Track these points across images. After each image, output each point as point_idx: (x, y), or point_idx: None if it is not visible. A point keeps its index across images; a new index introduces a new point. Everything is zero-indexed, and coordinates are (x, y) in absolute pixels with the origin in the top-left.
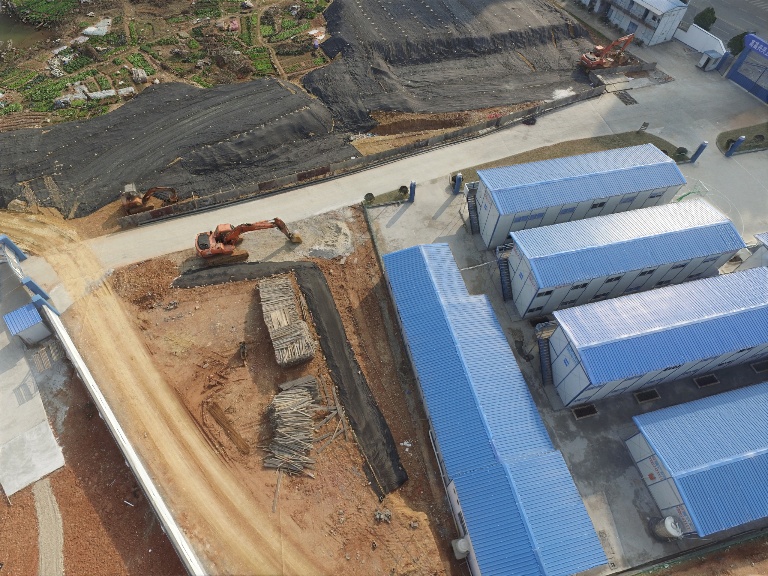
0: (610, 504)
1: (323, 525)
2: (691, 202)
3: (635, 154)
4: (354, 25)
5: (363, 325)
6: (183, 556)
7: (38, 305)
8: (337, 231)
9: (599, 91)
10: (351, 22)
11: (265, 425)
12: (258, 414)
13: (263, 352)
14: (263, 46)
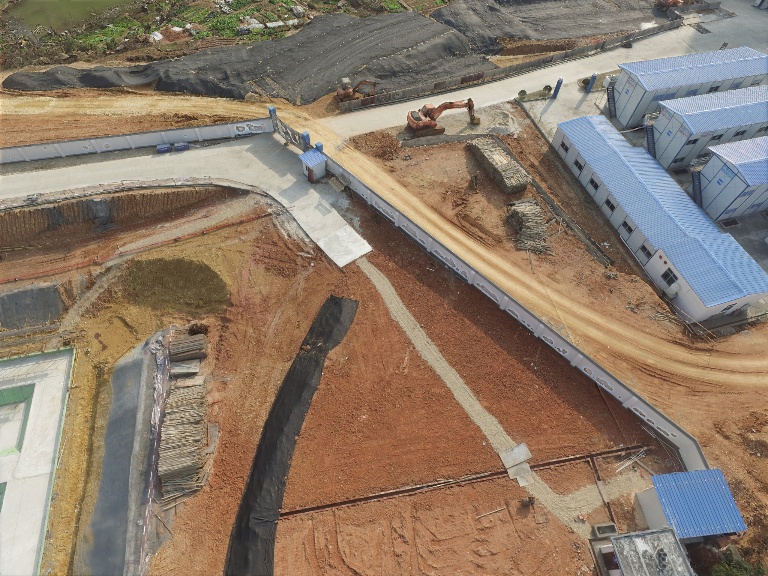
0: None
1: (571, 280)
2: None
3: (736, 53)
4: None
5: (547, 176)
6: (495, 284)
7: (319, 150)
8: (505, 116)
9: (678, 24)
10: None
11: (508, 226)
12: (500, 220)
13: (487, 185)
14: None
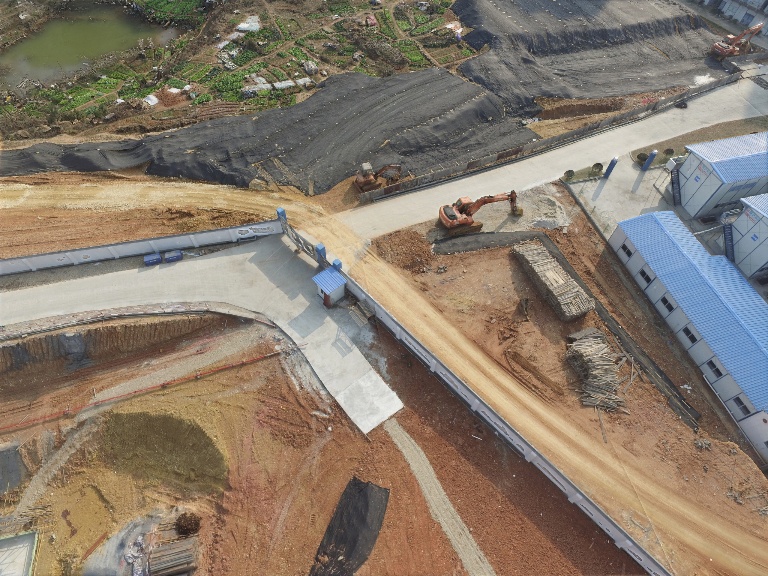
0: None
1: (653, 453)
2: None
3: None
4: (493, 18)
5: (606, 286)
6: (564, 475)
7: (337, 268)
8: (550, 204)
9: (736, 77)
10: (489, 16)
11: (568, 370)
12: (558, 361)
13: (539, 308)
14: (409, 39)
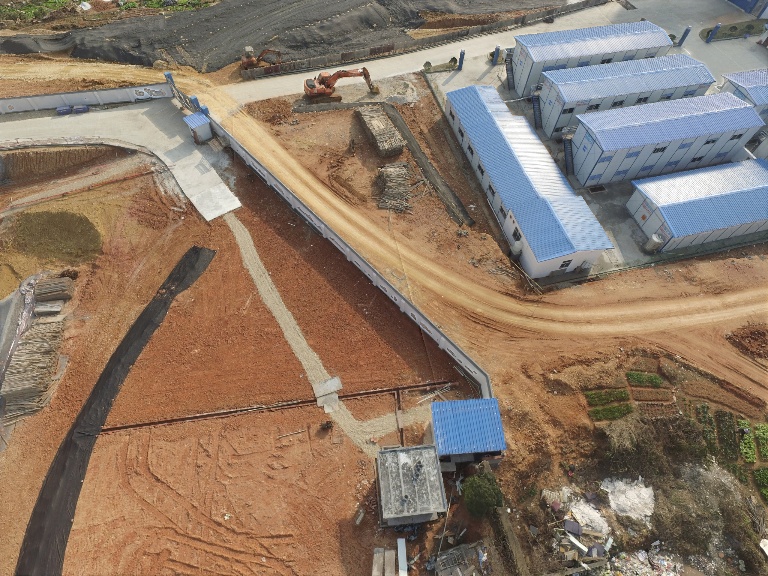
0: (615, 237)
1: (423, 237)
2: (676, 55)
3: (634, 26)
4: None
5: (432, 143)
6: (340, 237)
7: (205, 113)
8: (405, 87)
9: None
10: None
11: (375, 187)
12: (369, 181)
13: (366, 149)
14: None
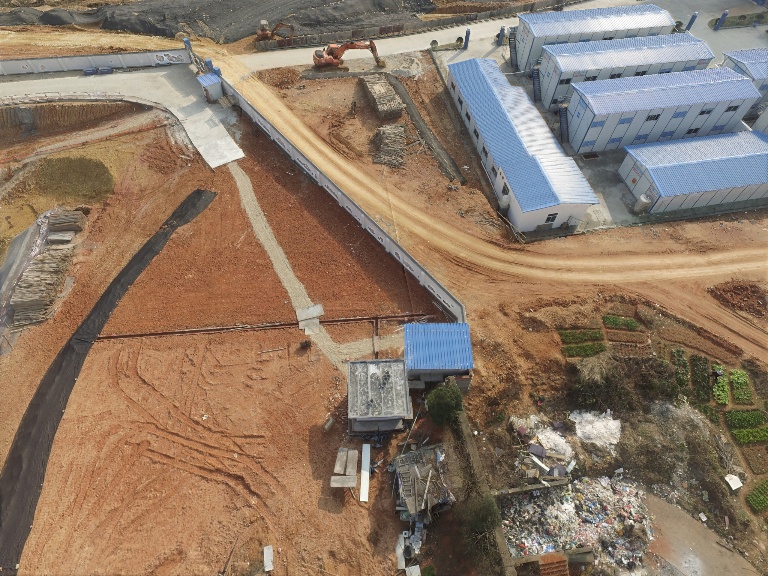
0: (605, 199)
1: (414, 189)
2: (677, 34)
3: (638, 8)
4: None
5: (433, 111)
6: (333, 182)
7: (217, 74)
8: (411, 62)
9: None
10: None
11: (372, 145)
12: (367, 140)
13: (367, 112)
14: None
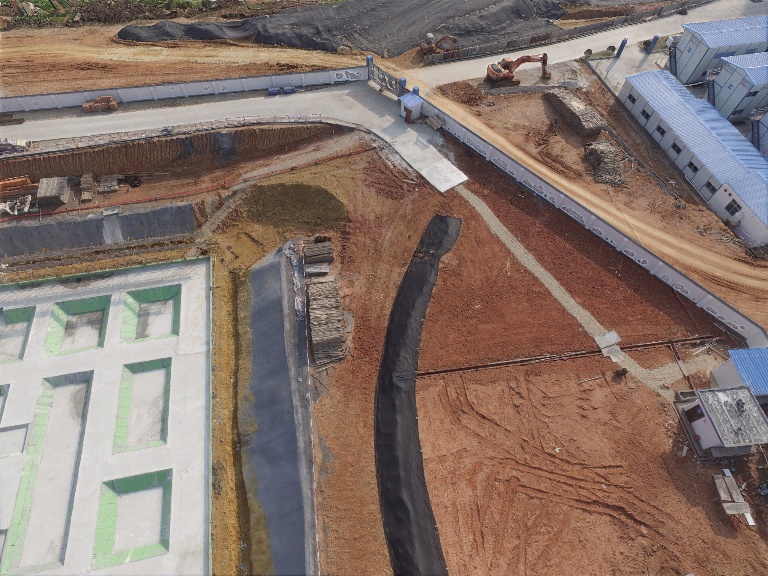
0: None
1: (645, 208)
2: None
3: None
4: None
5: (615, 124)
6: None
7: (416, 94)
8: (573, 72)
9: None
10: None
11: (586, 163)
12: (579, 158)
13: (565, 129)
14: None
